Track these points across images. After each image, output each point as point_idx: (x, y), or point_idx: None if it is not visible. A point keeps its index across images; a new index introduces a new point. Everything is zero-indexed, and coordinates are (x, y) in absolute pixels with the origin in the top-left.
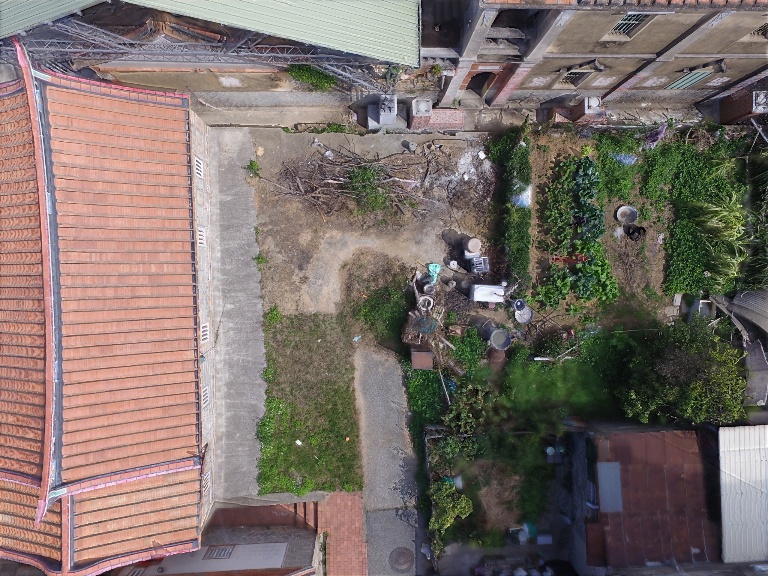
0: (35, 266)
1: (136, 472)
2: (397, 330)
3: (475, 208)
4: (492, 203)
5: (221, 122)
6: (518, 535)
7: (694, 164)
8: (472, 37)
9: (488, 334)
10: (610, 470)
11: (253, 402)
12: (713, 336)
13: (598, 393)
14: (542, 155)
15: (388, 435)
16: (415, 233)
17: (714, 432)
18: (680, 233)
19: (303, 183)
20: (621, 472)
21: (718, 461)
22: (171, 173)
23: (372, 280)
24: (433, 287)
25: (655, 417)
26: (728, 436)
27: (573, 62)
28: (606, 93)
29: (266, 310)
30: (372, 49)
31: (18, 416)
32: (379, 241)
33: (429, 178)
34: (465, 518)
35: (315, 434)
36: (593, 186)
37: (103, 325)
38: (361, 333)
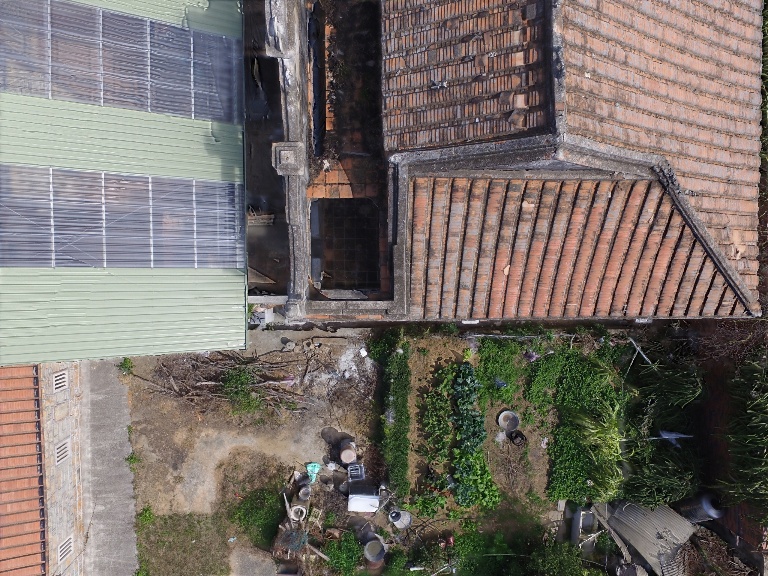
0: None
1: None
2: (271, 536)
3: (356, 406)
4: (373, 401)
5: None
6: None
7: (578, 370)
8: None
9: (366, 539)
10: None
11: None
12: (582, 571)
13: None
14: (422, 358)
15: None
16: (294, 431)
17: None
18: (563, 440)
19: (177, 382)
20: None
21: None
22: (16, 410)
23: (248, 481)
24: (309, 491)
25: None
26: None
27: None
28: None
29: (139, 510)
30: (187, 344)
31: None
32: (256, 440)
33: (309, 375)
34: None
35: None
36: (472, 394)
37: None
38: (236, 535)
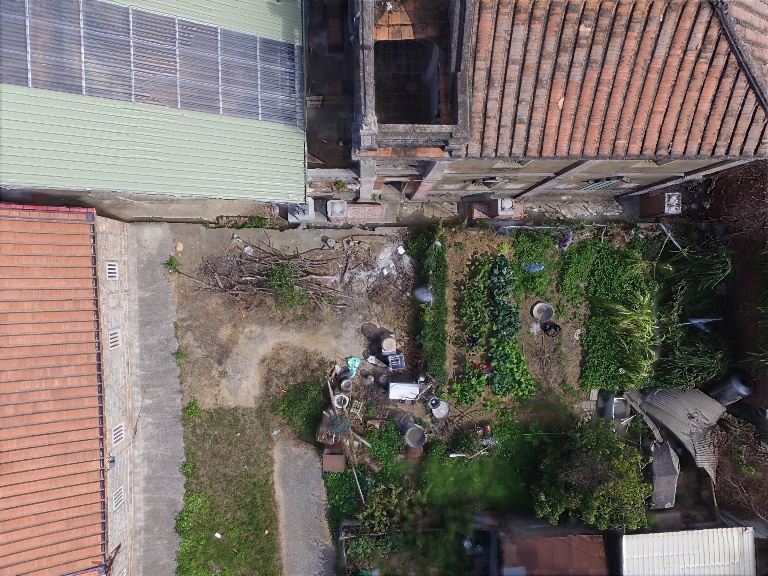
0: None
1: None
2: (314, 426)
3: (394, 302)
4: (411, 297)
5: (143, 215)
6: None
7: (609, 262)
8: (362, 169)
9: (406, 429)
10: (517, 575)
11: (172, 496)
12: (618, 443)
13: (515, 487)
14: (459, 252)
15: (308, 527)
16: (334, 327)
17: (620, 538)
18: (595, 330)
19: (222, 279)
20: None
21: (622, 569)
22: (75, 287)
23: (291, 375)
24: (351, 383)
25: (566, 517)
26: (632, 544)
27: (475, 177)
28: (522, 192)
29: (185, 404)
30: (253, 192)
31: None
32: (298, 335)
33: (349, 273)
34: None
35: (234, 527)
36: (508, 285)
37: (2, 443)
38: (280, 427)
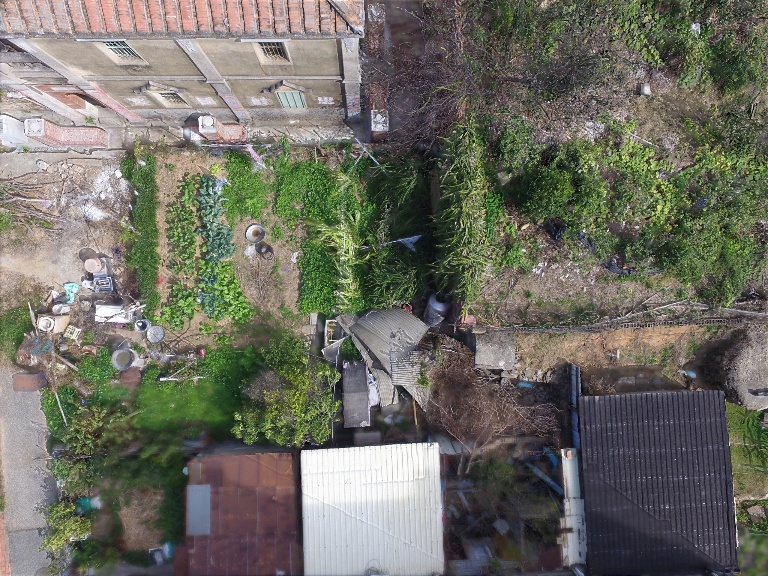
0: None
1: None
2: None
3: (113, 227)
4: (130, 222)
5: None
6: (154, 555)
7: (323, 183)
8: None
9: None
10: (199, 493)
11: None
12: (300, 358)
13: None
14: (170, 174)
15: (29, 455)
16: (52, 252)
17: None
18: (310, 252)
19: None
20: (211, 495)
21: (300, 484)
22: None
23: (5, 300)
24: (63, 307)
25: None
26: (311, 459)
27: (135, 84)
28: None
29: None
30: None
31: None
32: (14, 261)
33: (65, 197)
34: (107, 538)
35: None
36: (216, 205)
37: None
38: None
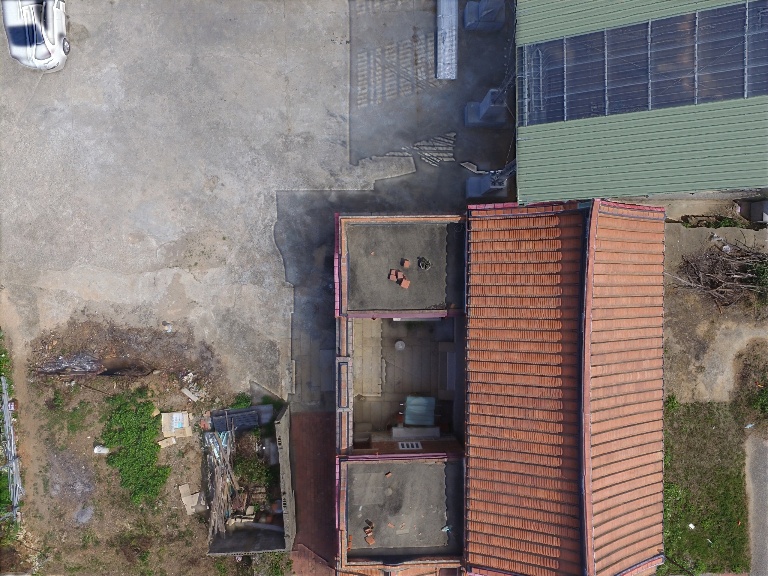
0: (552, 379)
1: (629, 573)
2: None
3: None
4: None
5: None
6: None
7: None
8: None
9: None
10: None
11: None
12: None
13: None
14: None
15: None
16: None
17: None
18: None
19: (704, 277)
20: None
21: None
22: (651, 283)
23: (767, 370)
24: None
25: None
26: None
27: None
28: None
29: (664, 398)
30: None
31: (523, 520)
32: None
33: None
34: None
35: (708, 518)
36: None
37: (608, 434)
38: (756, 421)
